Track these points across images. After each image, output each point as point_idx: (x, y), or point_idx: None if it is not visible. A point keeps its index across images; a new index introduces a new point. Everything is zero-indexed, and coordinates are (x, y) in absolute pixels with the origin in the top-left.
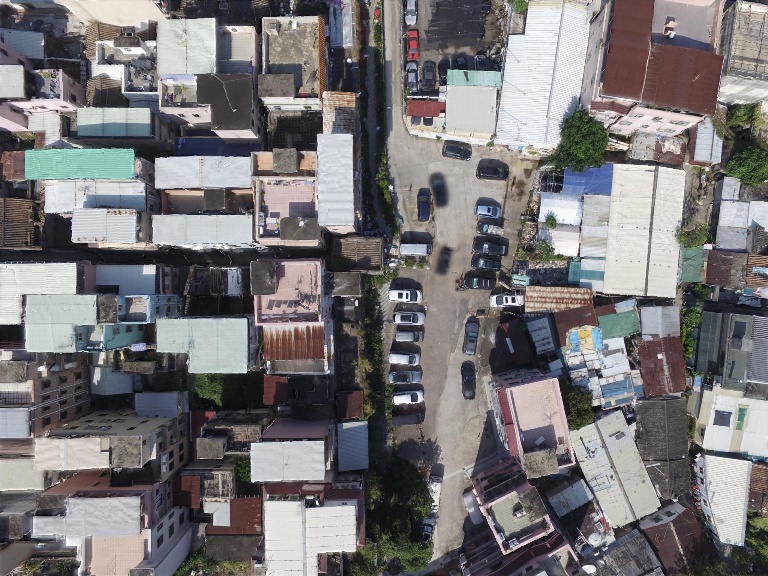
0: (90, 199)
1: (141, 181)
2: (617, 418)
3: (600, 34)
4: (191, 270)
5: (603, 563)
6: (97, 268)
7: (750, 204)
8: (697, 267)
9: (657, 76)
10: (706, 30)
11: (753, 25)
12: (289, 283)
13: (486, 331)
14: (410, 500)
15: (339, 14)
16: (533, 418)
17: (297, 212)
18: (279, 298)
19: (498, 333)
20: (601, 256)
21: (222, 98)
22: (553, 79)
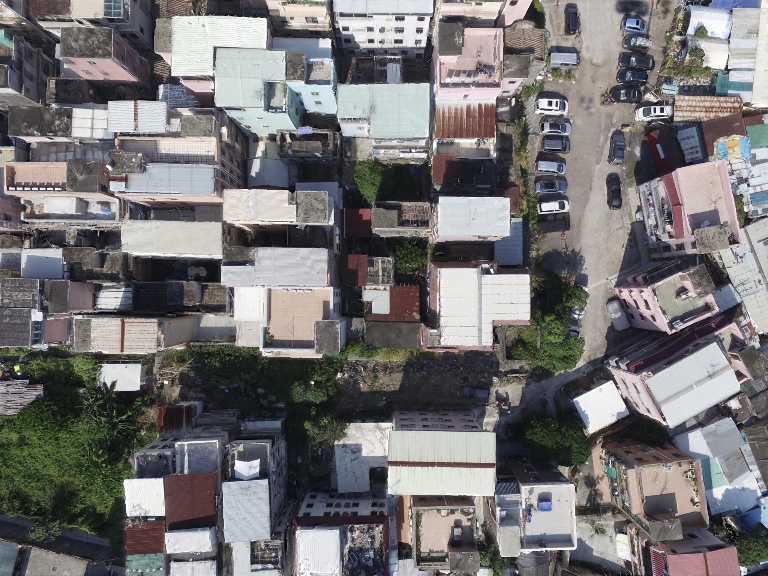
0: None
1: None
2: (765, 225)
3: None
4: (353, 61)
5: None
6: (274, 40)
7: None
8: None
9: None
10: None
11: None
12: (468, 53)
13: (631, 144)
14: None
15: None
16: (698, 202)
17: None
18: (458, 68)
19: (643, 146)
20: (750, 67)
21: None
22: None
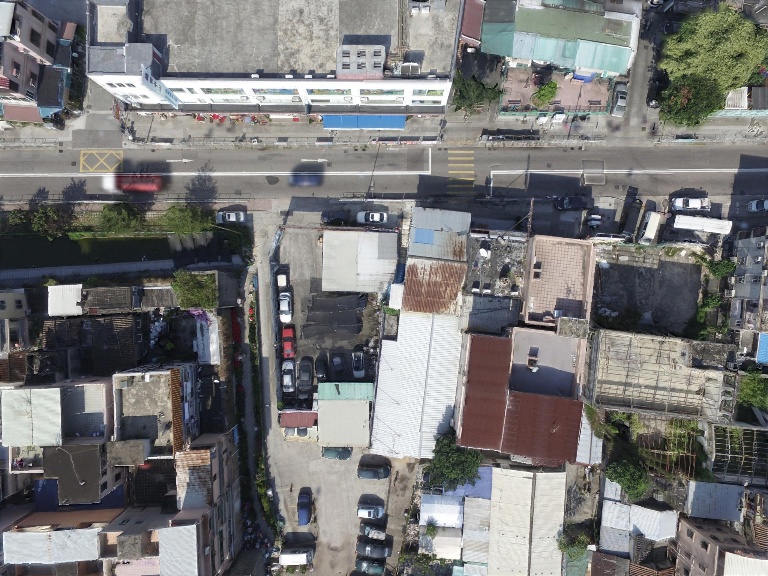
0: None
1: None
2: None
3: (464, 365)
4: None
5: None
6: None
7: (631, 508)
8: (582, 568)
9: (516, 425)
10: (570, 360)
11: (620, 348)
12: None
13: None
14: None
15: (206, 331)
16: None
17: None
18: None
19: None
20: (483, 562)
21: (69, 471)
22: (425, 392)
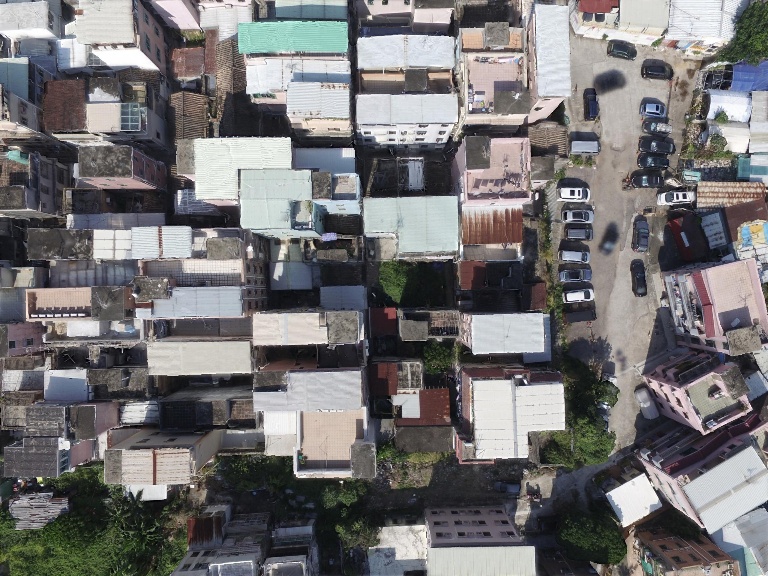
0: (297, 77)
1: (347, 59)
2: None
3: None
4: (375, 162)
5: None
6: (296, 151)
7: None
8: None
9: None
10: None
11: None
12: (495, 162)
13: (654, 229)
14: None
15: None
16: (728, 300)
17: None
18: (485, 177)
19: (666, 231)
20: None
21: None
22: None
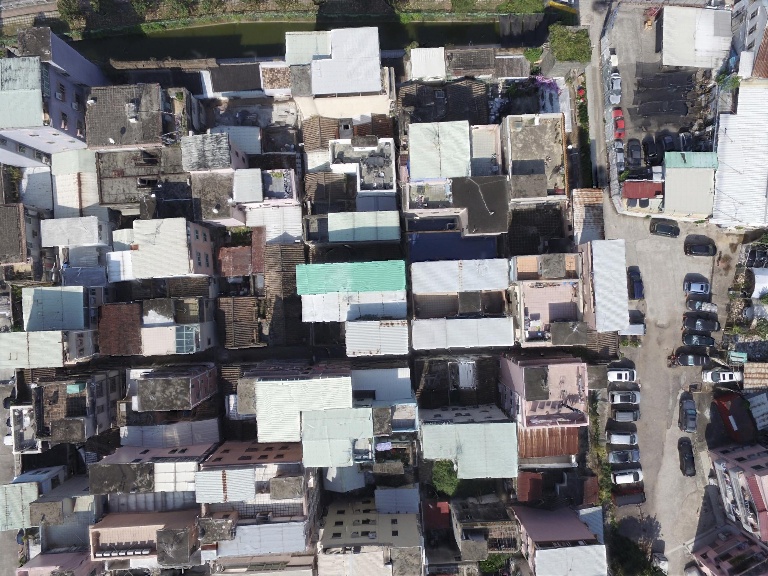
0: (354, 309)
1: None
2: None
3: None
4: (426, 364)
5: None
6: (352, 374)
7: None
8: None
9: None
10: None
11: None
12: (551, 384)
13: (700, 407)
14: None
15: (556, 100)
16: None
17: (557, 313)
18: None
19: (712, 408)
20: None
21: (478, 201)
22: None
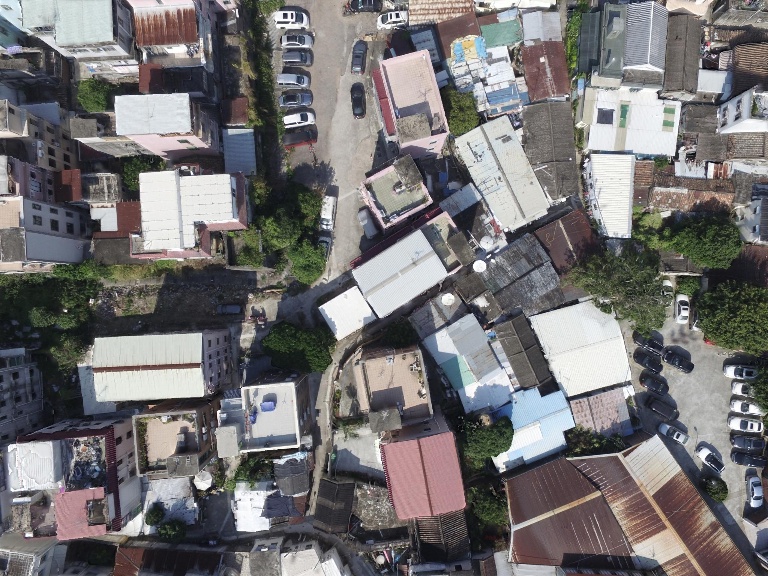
0: None
1: None
2: (503, 122)
3: None
4: None
5: (494, 262)
6: None
7: None
8: None
9: None
10: None
11: None
12: None
13: (374, 53)
14: (305, 220)
15: None
16: (408, 96)
17: None
18: None
19: (386, 54)
20: None
21: None
22: None
